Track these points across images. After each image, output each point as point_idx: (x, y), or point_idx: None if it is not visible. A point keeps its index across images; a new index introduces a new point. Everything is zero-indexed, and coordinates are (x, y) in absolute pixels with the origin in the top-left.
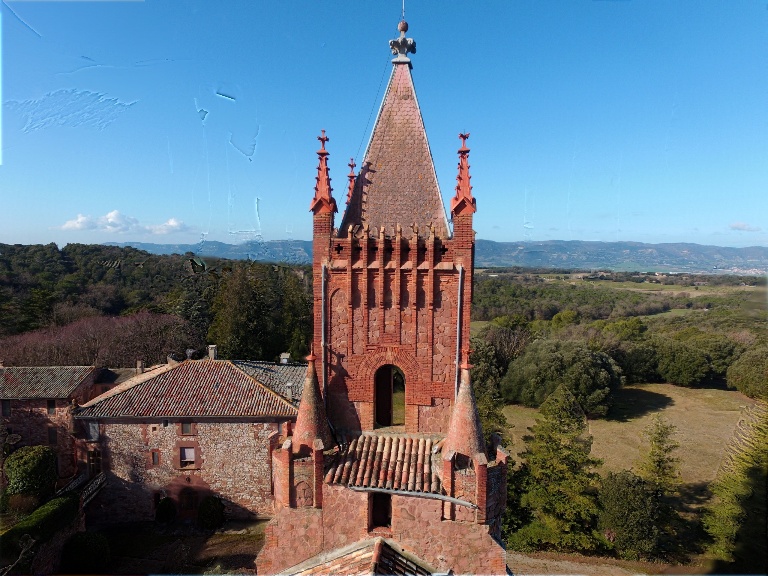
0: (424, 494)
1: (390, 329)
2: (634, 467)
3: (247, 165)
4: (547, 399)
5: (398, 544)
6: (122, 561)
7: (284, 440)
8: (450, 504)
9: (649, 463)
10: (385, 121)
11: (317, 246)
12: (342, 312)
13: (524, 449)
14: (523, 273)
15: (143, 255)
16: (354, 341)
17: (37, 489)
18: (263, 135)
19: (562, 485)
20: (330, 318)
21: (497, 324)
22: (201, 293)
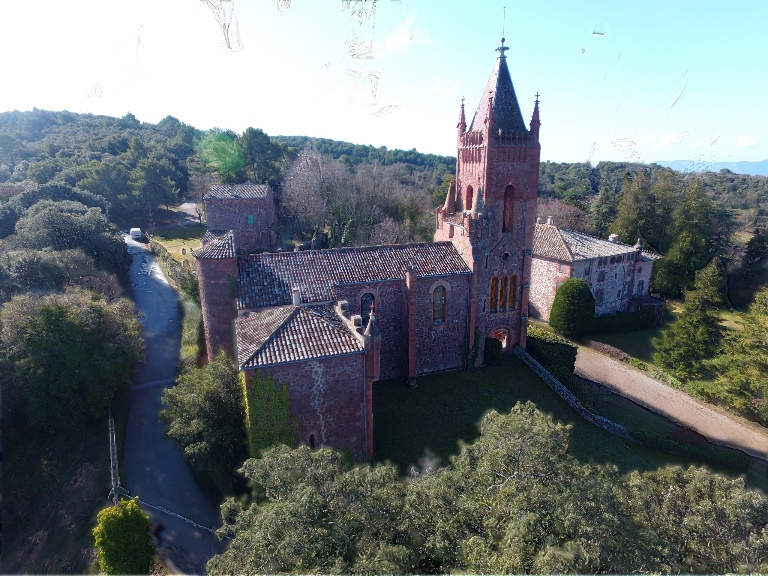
0: None
1: None
2: None
3: (631, 82)
4: None
5: None
6: None
7: None
8: None
9: None
10: None
11: None
12: None
13: None
14: None
15: None
16: None
17: None
18: (646, 53)
19: (739, 355)
20: (459, 168)
21: None
22: (598, 191)
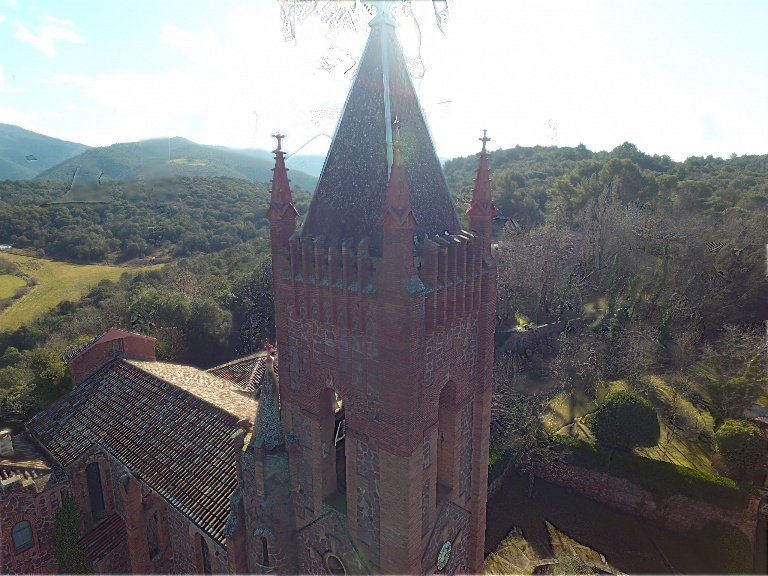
0: None
1: None
2: None
3: None
4: None
5: None
6: None
7: None
8: None
9: None
10: None
11: None
12: None
13: None
14: None
15: None
16: None
17: (728, 461)
18: None
19: None
20: None
21: None
22: None
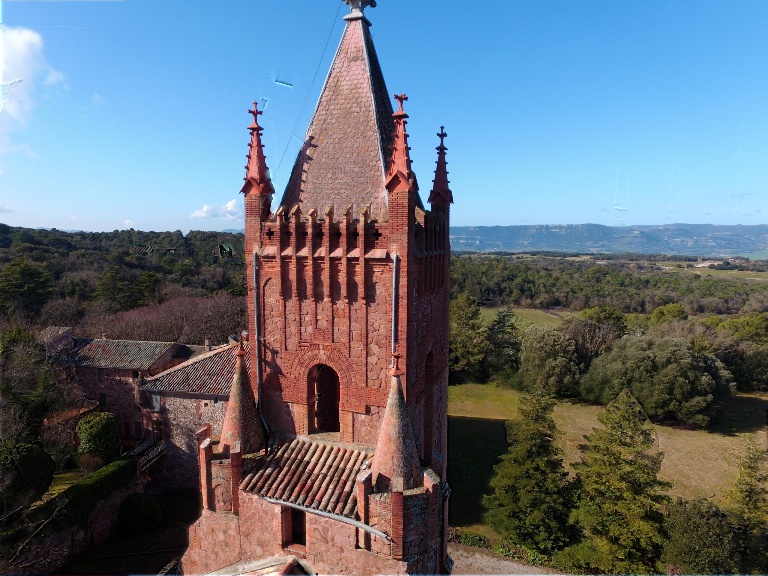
0: (335, 516)
1: (322, 325)
2: (717, 494)
3: None
4: (608, 406)
5: (312, 567)
6: (171, 524)
7: (220, 437)
8: (364, 531)
9: (735, 492)
10: (332, 88)
11: (249, 231)
12: (275, 304)
13: (579, 459)
14: (613, 261)
15: (174, 241)
16: (287, 336)
17: (102, 451)
18: None
19: (618, 505)
20: (263, 310)
21: (581, 316)
22: None
